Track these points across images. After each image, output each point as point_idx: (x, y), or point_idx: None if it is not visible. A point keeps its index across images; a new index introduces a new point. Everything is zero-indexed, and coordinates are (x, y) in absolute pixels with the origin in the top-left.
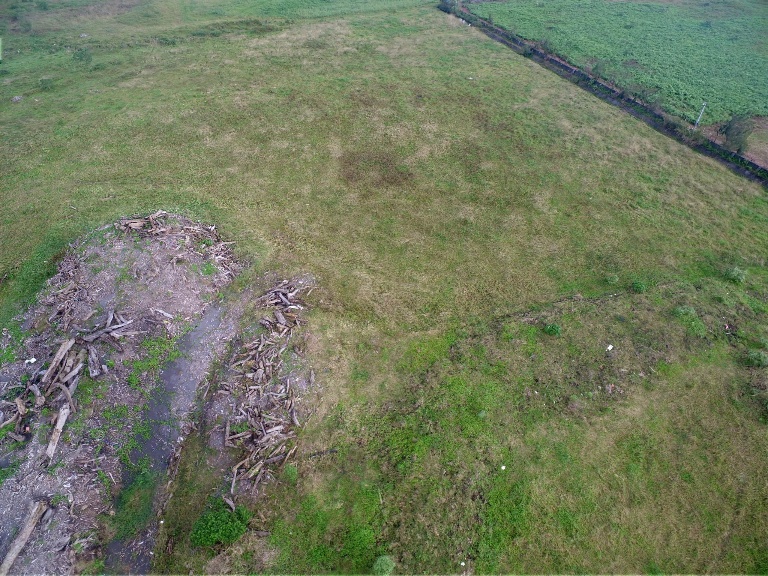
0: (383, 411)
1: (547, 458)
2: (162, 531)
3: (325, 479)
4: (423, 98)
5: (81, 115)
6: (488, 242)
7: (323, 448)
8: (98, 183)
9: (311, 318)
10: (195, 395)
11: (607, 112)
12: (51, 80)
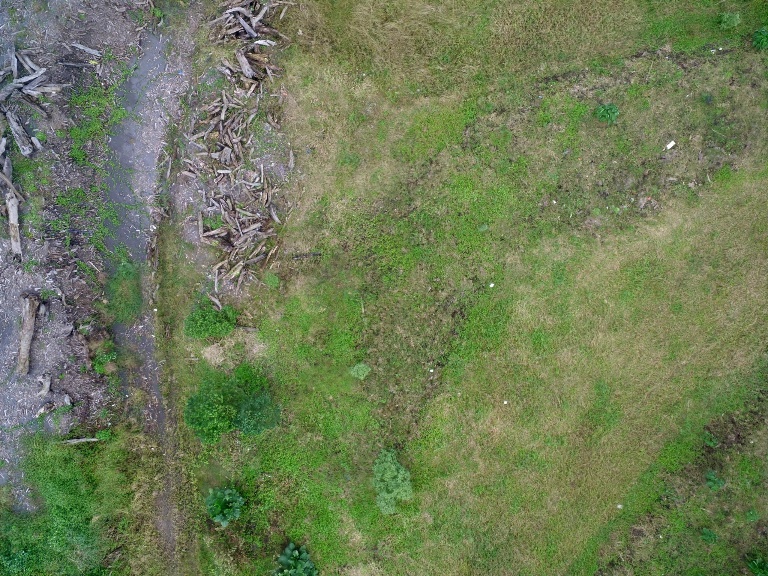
0: (373, 210)
1: (541, 278)
2: (157, 319)
3: (308, 282)
4: None
5: None
6: None
7: (306, 250)
8: None
9: (287, 63)
10: (157, 173)
11: None
12: None
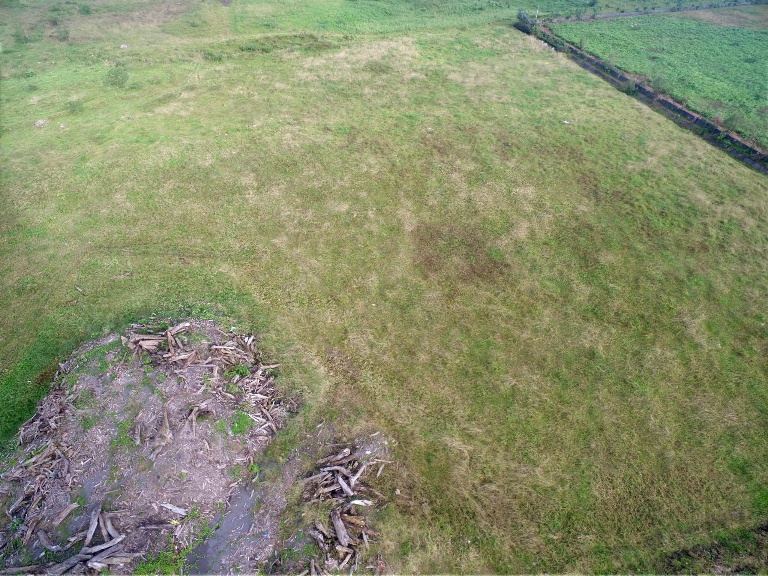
0: None
1: None
2: None
3: None
4: (511, 147)
5: (108, 149)
6: (631, 396)
7: None
8: (114, 250)
9: (384, 526)
10: None
11: (752, 182)
12: (81, 101)
